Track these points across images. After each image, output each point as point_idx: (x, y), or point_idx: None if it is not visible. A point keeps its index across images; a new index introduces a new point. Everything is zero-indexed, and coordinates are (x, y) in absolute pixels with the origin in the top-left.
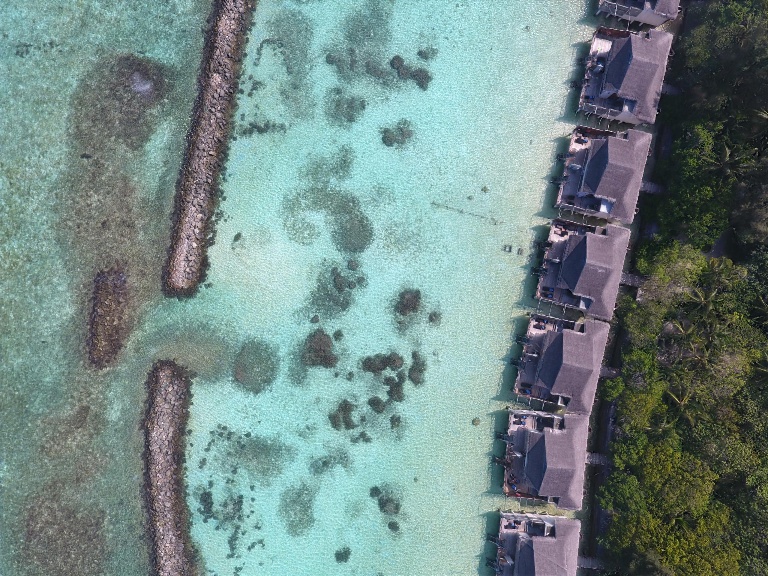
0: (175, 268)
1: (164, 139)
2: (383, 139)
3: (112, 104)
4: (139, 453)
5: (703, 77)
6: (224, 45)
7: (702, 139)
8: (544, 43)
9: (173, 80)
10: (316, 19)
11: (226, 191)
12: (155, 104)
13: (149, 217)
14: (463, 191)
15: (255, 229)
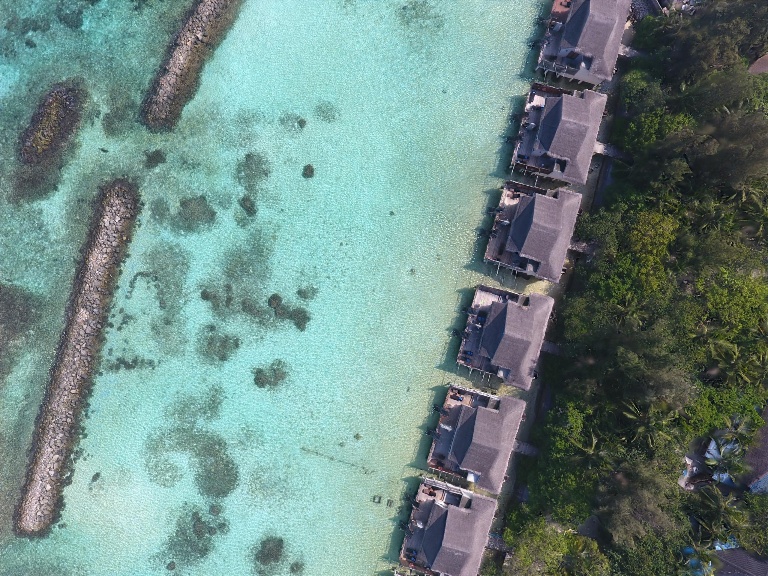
0: (26, 511)
1: (27, 372)
2: (255, 380)
3: None
4: None
5: (579, 351)
6: (93, 280)
7: (570, 423)
8: (429, 287)
9: (40, 310)
10: (194, 252)
11: (88, 428)
12: (19, 335)
13: (5, 453)
14: (335, 437)
15: (115, 469)
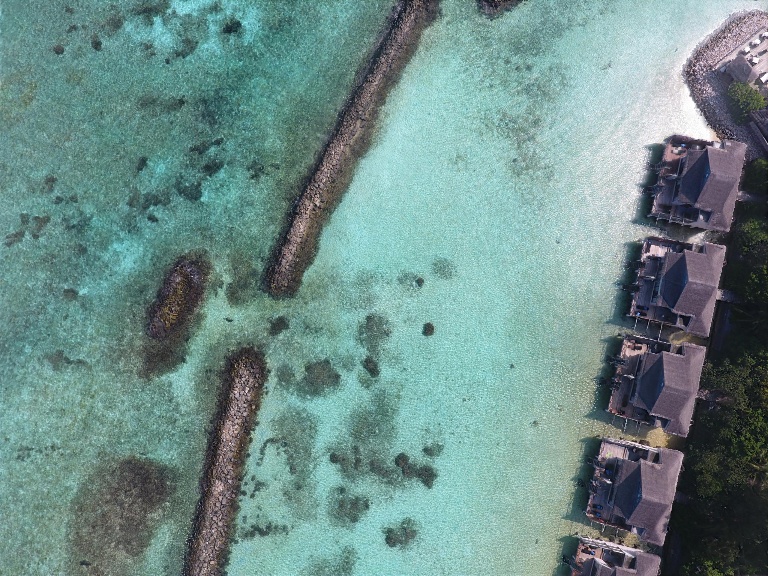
0: None
1: (165, 543)
2: (386, 540)
3: (113, 509)
4: None
5: (714, 508)
6: (227, 452)
7: None
8: (552, 438)
9: (175, 482)
10: (321, 416)
11: None
12: (156, 508)
13: None
14: None
15: None
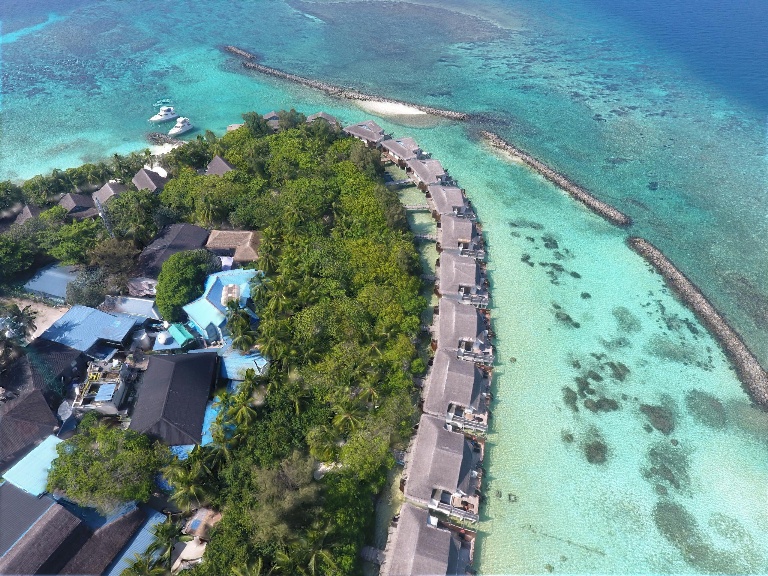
0: None
1: None
2: None
3: None
4: (759, 358)
5: None
6: None
7: None
8: None
9: None
10: None
11: None
12: None
13: None
14: (575, 568)
15: None
